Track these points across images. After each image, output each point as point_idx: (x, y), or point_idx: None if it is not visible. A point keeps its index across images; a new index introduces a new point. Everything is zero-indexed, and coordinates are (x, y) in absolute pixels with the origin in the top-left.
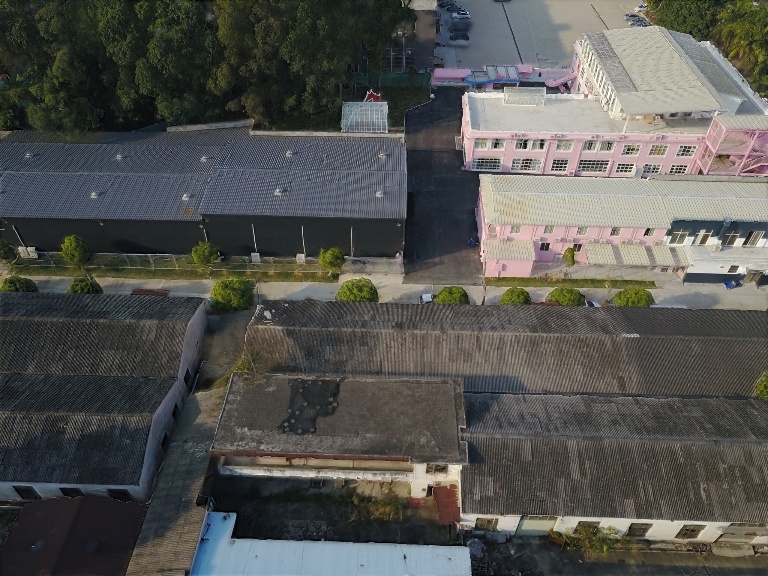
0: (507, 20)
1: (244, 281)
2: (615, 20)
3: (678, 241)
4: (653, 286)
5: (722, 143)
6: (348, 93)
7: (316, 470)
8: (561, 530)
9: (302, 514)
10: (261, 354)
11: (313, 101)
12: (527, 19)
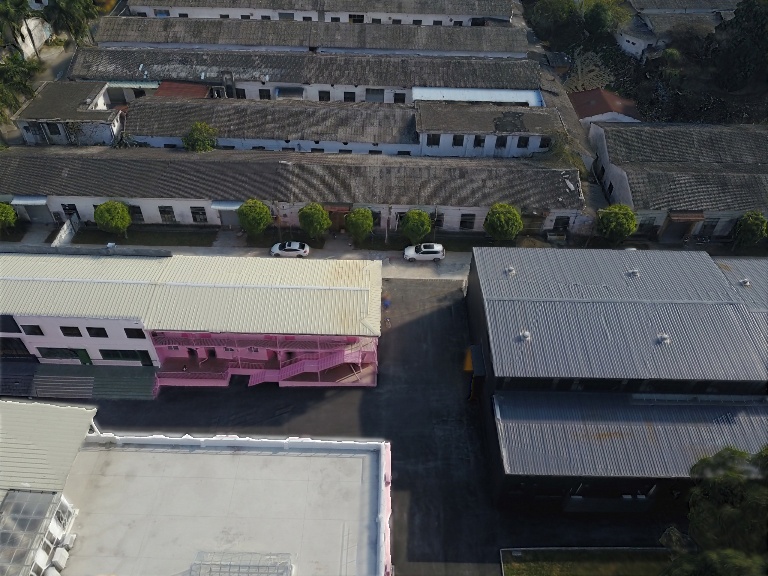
0: None
1: (609, 211)
2: None
3: None
4: None
5: None
6: None
7: None
8: None
9: None
10: None
11: None
12: None
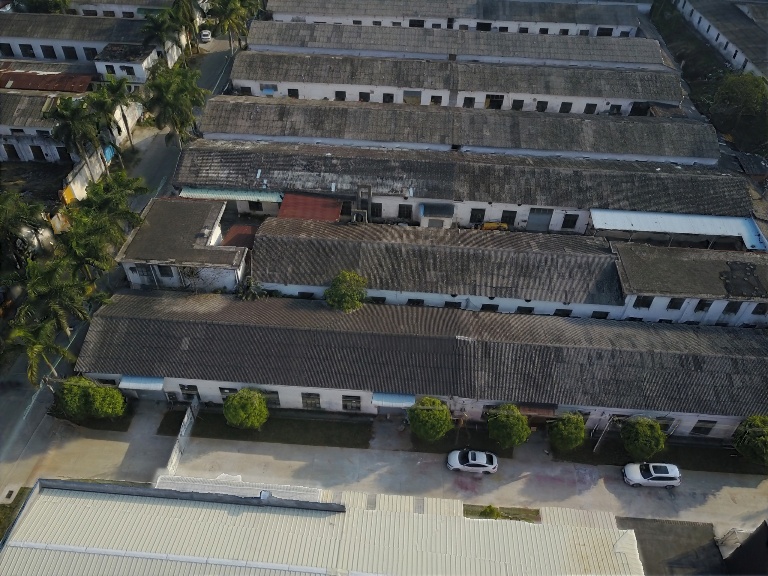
0: None
1: None
2: None
3: None
4: None
5: None
6: None
7: None
8: None
9: None
10: None
11: None
12: None
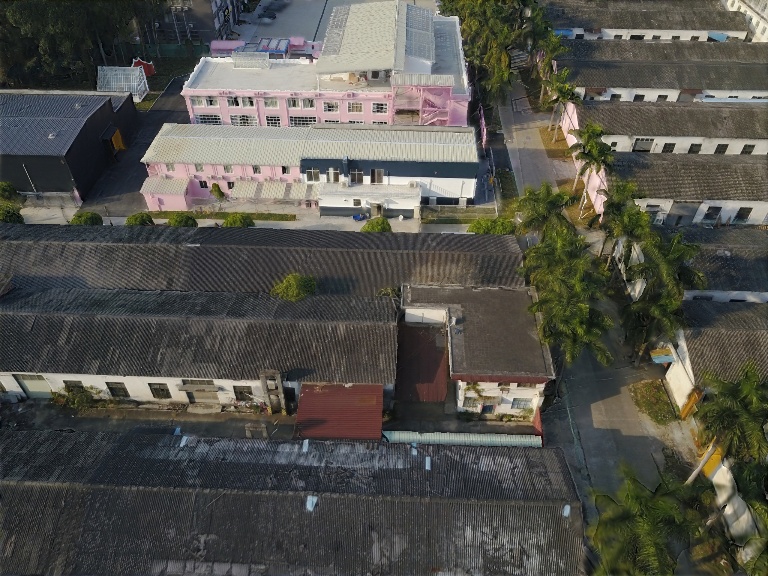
0: (326, 2)
1: None
2: (426, 2)
3: (316, 179)
4: (292, 218)
5: (395, 99)
6: (112, 60)
7: None
8: None
9: None
10: None
11: (54, 63)
12: (344, 1)
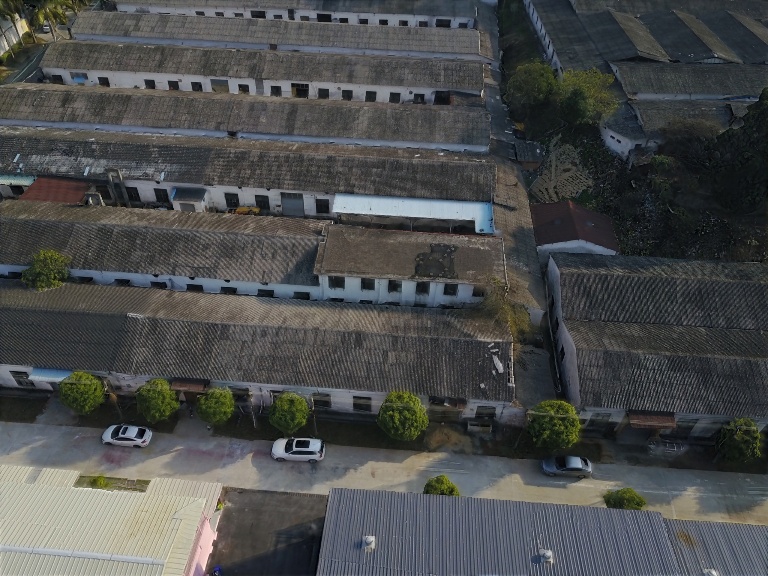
0: None
1: (542, 414)
2: None
3: None
4: None
5: None
6: None
7: None
8: None
9: None
10: None
11: None
12: None
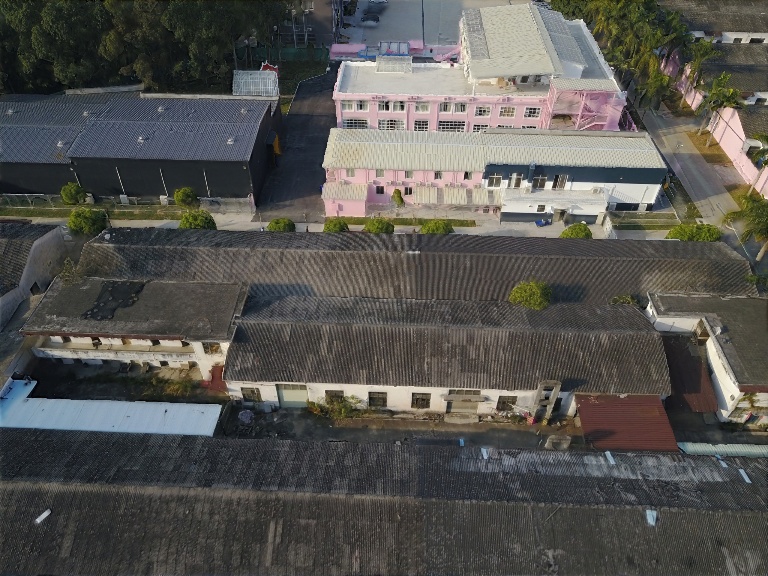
0: (422, 4)
1: (95, 211)
2: None
3: (496, 185)
4: (473, 224)
5: (556, 103)
6: (243, 64)
7: (114, 351)
8: (315, 400)
9: (107, 392)
10: (91, 266)
11: (199, 67)
12: (441, 4)
